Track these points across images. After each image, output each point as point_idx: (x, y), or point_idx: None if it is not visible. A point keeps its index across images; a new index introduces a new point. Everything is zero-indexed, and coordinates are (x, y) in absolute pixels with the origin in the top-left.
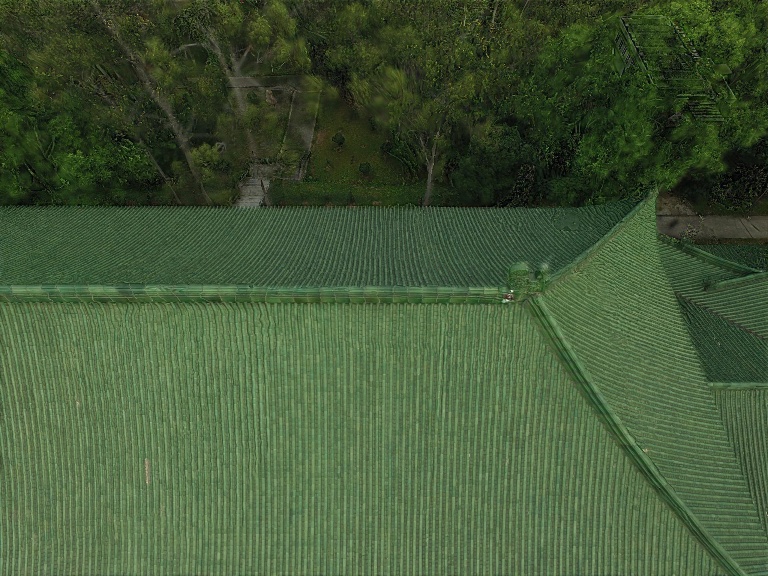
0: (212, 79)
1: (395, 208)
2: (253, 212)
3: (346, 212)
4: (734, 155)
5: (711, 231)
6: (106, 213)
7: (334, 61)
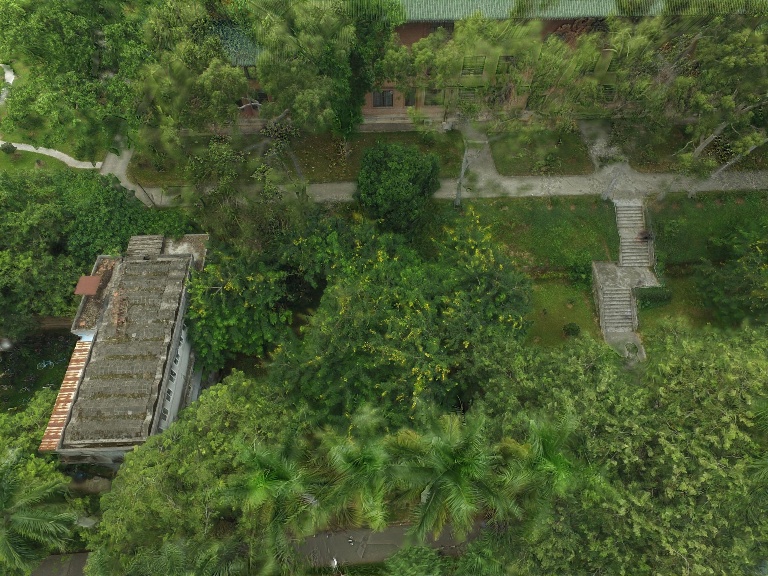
0: (766, 285)
1: (498, 7)
2: (588, 8)
3: (529, 8)
4: (148, 208)
5: (196, 192)
6: (680, 4)
7: (625, 358)
